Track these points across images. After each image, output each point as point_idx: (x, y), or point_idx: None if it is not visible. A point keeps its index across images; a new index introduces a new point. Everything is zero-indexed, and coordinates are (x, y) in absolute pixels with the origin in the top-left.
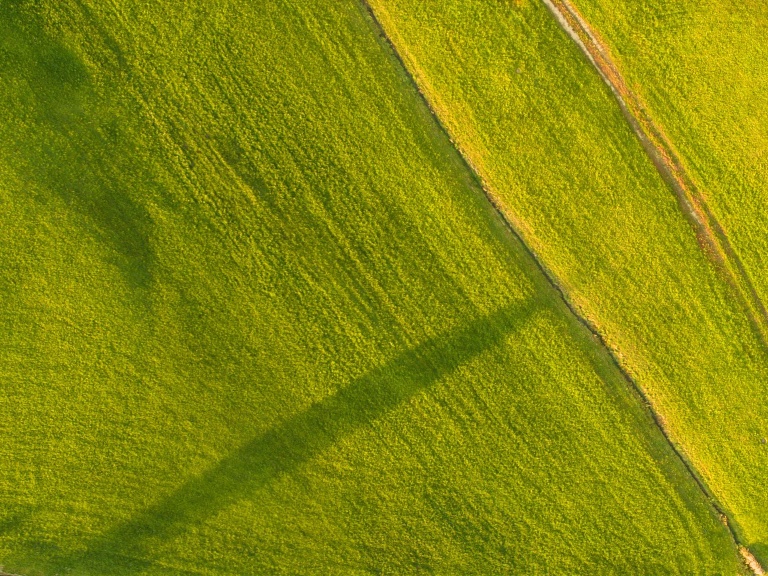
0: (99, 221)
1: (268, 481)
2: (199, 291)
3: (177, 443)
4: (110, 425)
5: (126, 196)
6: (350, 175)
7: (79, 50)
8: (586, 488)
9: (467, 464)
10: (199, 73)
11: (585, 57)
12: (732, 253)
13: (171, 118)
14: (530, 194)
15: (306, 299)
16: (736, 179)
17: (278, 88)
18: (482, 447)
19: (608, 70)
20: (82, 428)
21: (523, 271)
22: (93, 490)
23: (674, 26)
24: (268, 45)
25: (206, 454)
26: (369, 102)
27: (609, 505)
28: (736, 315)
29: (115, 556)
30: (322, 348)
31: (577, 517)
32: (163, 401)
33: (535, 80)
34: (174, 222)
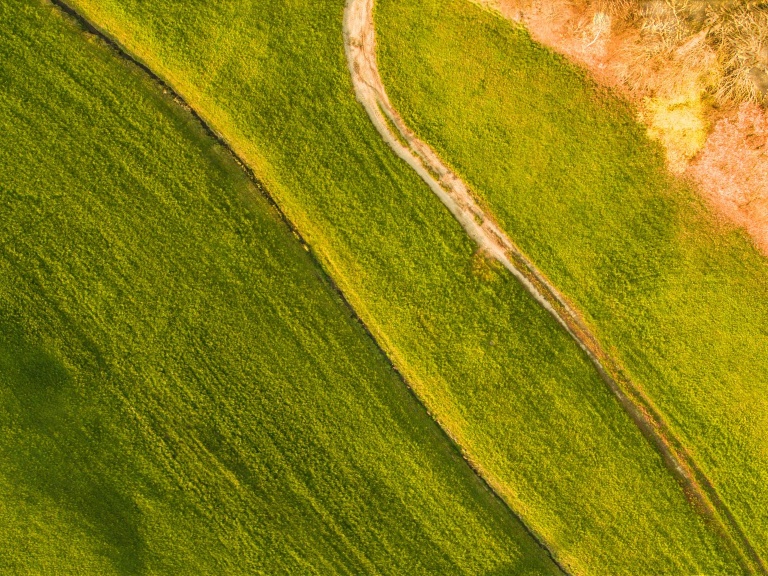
0: (89, 516)
1: None
2: (189, 574)
3: None
4: None
5: (113, 489)
6: (330, 453)
7: (59, 354)
8: None
9: None
10: (176, 367)
11: (558, 325)
12: (721, 505)
13: (152, 412)
14: (511, 460)
15: (294, 575)
16: (720, 433)
17: (254, 375)
18: None
19: (582, 335)
20: None
21: (509, 535)
22: None
23: (647, 289)
24: (241, 335)
25: None
26: (344, 383)
27: None
28: (729, 565)
29: None
30: None
31: None
32: None
33: (509, 351)
34: (161, 510)
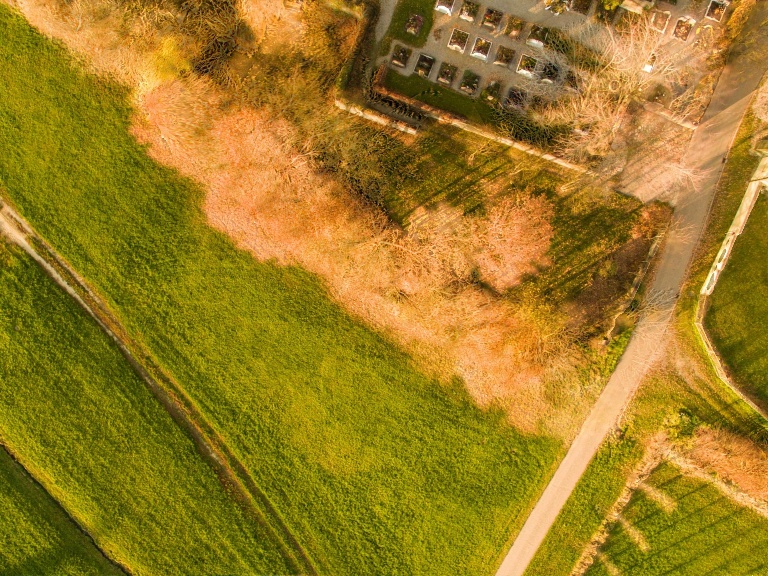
0: None
1: None
2: None
3: None
4: None
5: None
6: None
7: None
8: None
9: None
10: None
11: (82, 310)
12: (258, 492)
13: None
14: (45, 446)
15: None
16: (251, 420)
17: None
18: None
19: (108, 321)
20: None
21: (47, 520)
22: None
23: (167, 274)
24: None
25: None
26: None
27: None
28: (269, 553)
29: None
30: None
31: None
32: None
33: (34, 336)
34: None
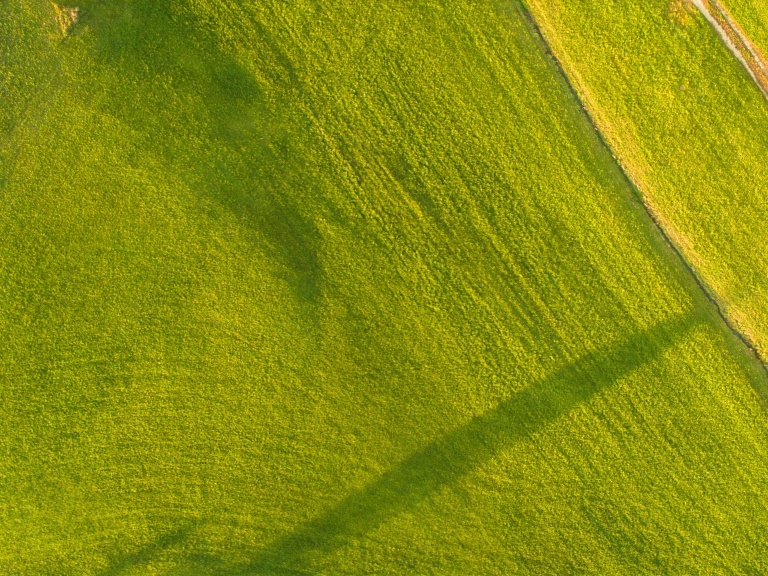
0: (269, 236)
1: (429, 494)
2: (365, 306)
3: (341, 456)
4: (276, 439)
5: (295, 211)
6: (515, 191)
7: (252, 67)
8: (739, 500)
9: (623, 476)
10: (369, 90)
11: (747, 74)
12: None
13: (341, 134)
14: (690, 210)
15: (469, 313)
16: None
17: (446, 104)
18: (638, 460)
19: None
20: (248, 442)
21: (682, 286)
22: (257, 503)
23: None
24: (437, 62)
25: (369, 467)
26: (535, 118)
27: (761, 517)
28: None
29: (277, 569)
30: (484, 362)
31: (730, 529)
32: (328, 415)
33: (698, 97)
34: (342, 237)
